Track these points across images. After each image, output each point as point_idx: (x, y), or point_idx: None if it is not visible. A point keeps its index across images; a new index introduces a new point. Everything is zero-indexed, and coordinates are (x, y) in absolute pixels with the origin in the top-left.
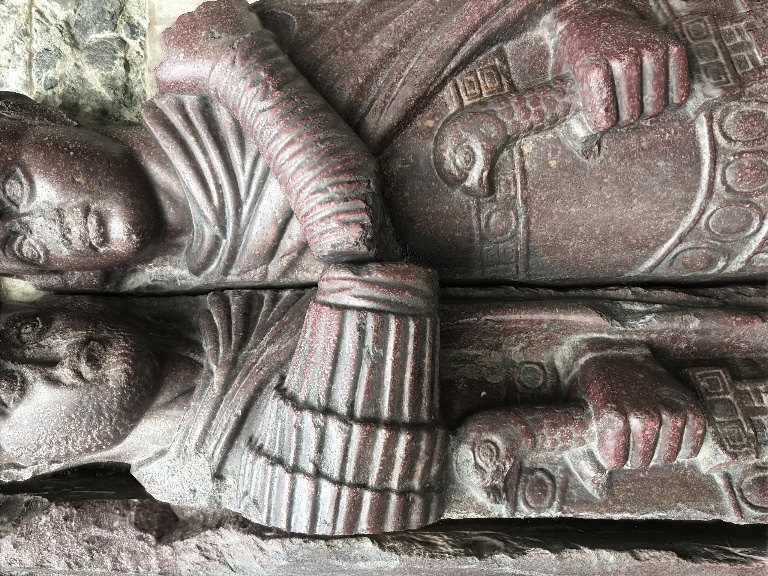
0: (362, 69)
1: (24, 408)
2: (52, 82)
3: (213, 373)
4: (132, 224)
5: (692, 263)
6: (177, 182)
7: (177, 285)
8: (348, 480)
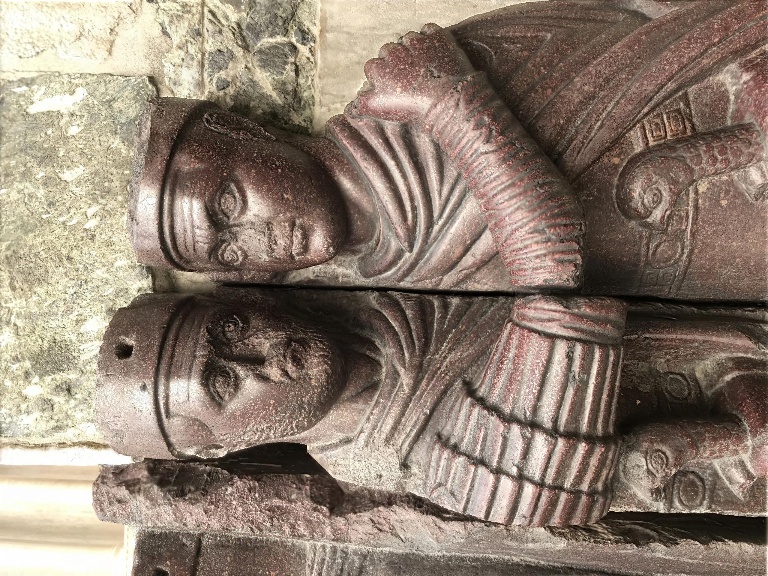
0: (564, 110)
1: (237, 401)
2: (224, 83)
3: (399, 374)
4: (331, 238)
5: None
6: (368, 198)
7: (338, 281)
8: (548, 483)
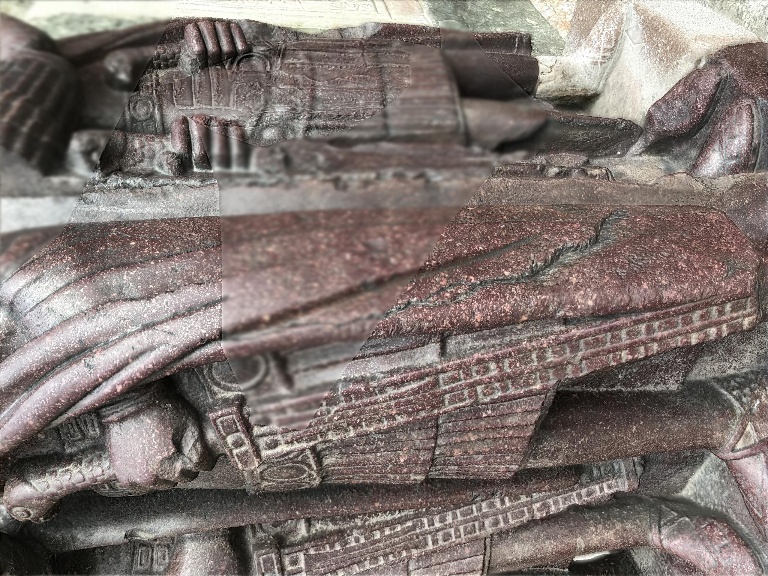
0: None
1: None
2: None
3: None
4: None
5: None
6: None
7: None
8: None
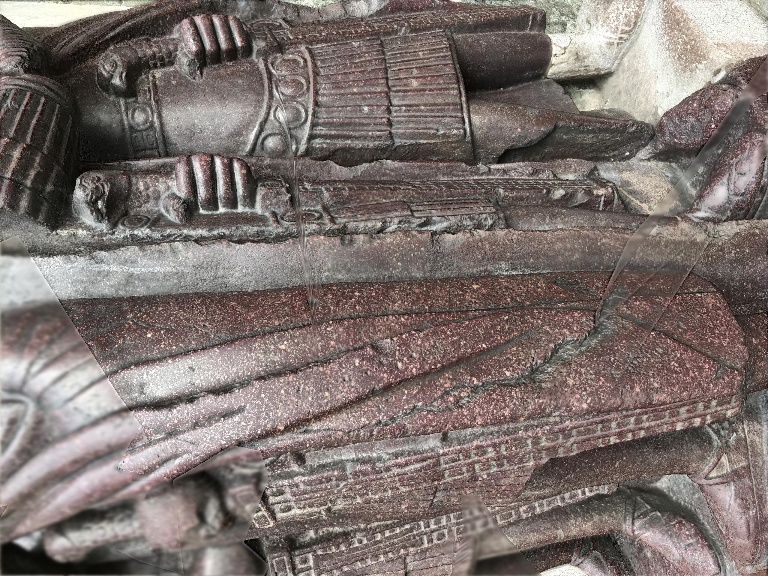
0: (54, 31)
1: None
2: None
3: None
4: None
5: (275, 147)
6: None
7: None
8: None
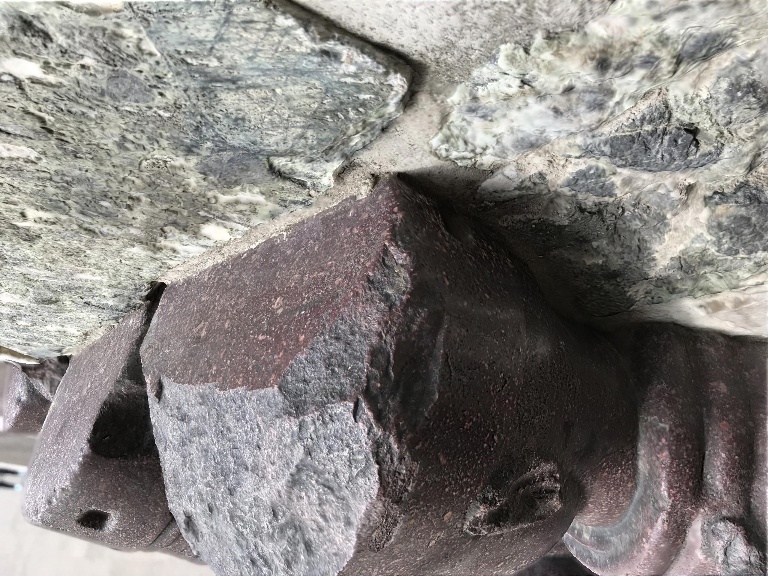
0: None
1: None
2: (599, 189)
3: None
4: None
5: None
6: None
7: None
8: None
